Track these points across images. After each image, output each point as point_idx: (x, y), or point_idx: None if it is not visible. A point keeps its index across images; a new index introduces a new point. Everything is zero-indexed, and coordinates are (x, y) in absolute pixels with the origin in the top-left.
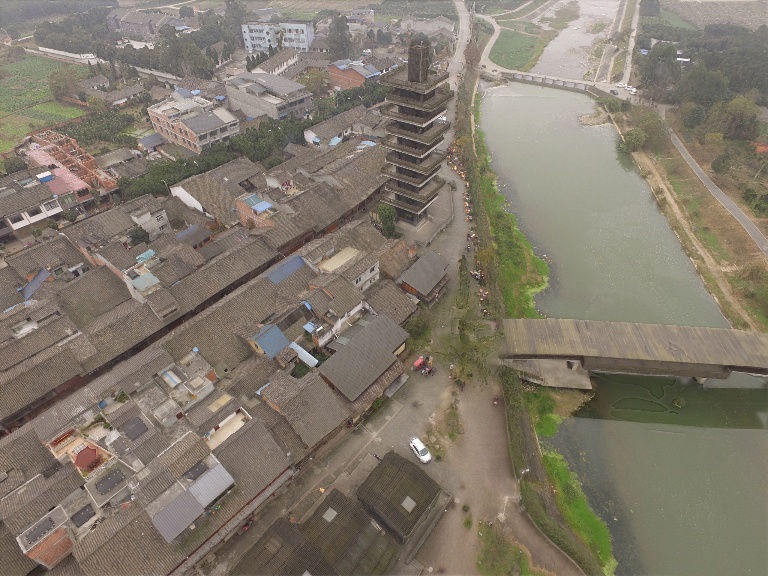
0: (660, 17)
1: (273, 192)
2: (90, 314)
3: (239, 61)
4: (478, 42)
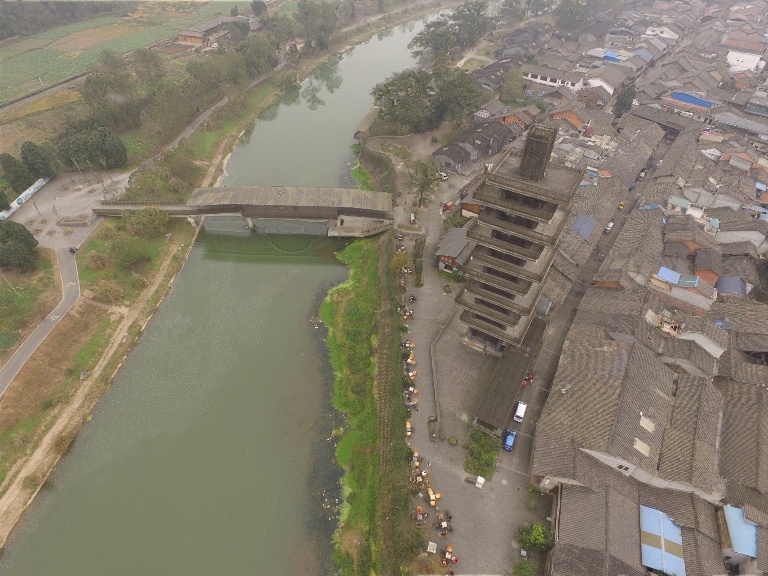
0: None
1: None
2: (708, 216)
3: None
4: None
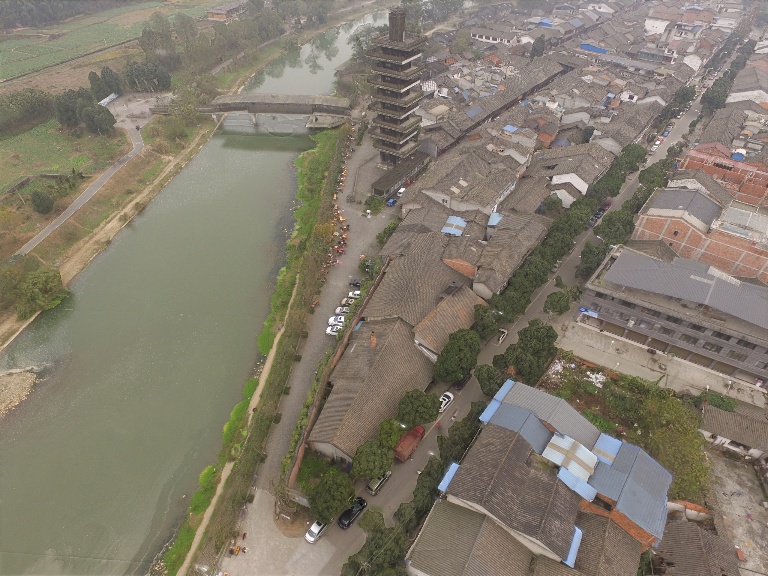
0: None
1: None
2: None
3: None
4: None
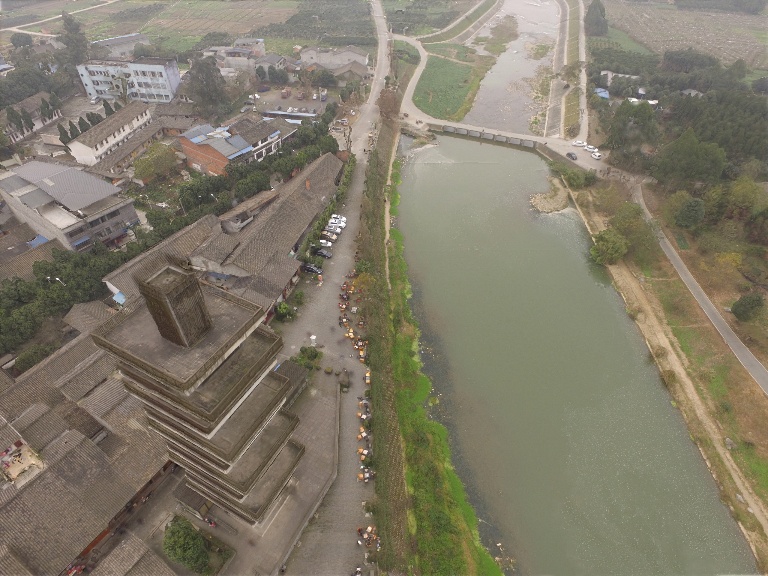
0: (608, 37)
1: None
2: None
3: (72, 118)
4: (399, 78)
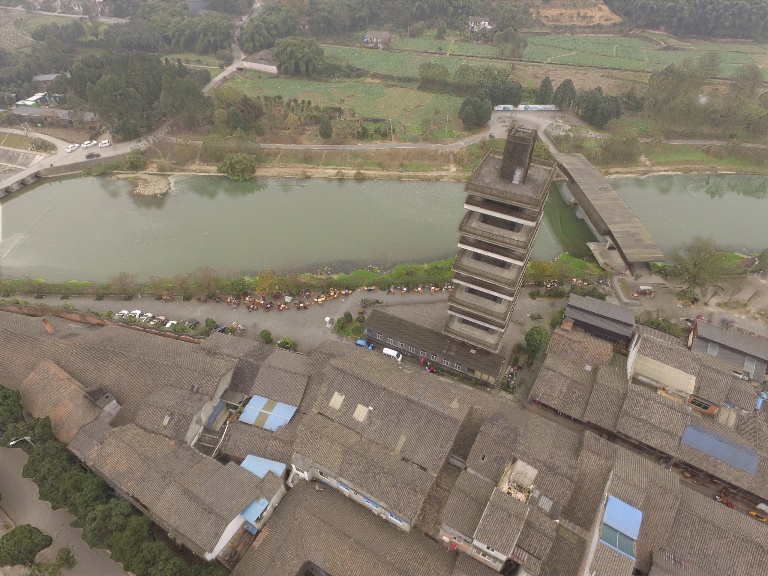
0: None
1: (541, 528)
2: None
3: None
4: None
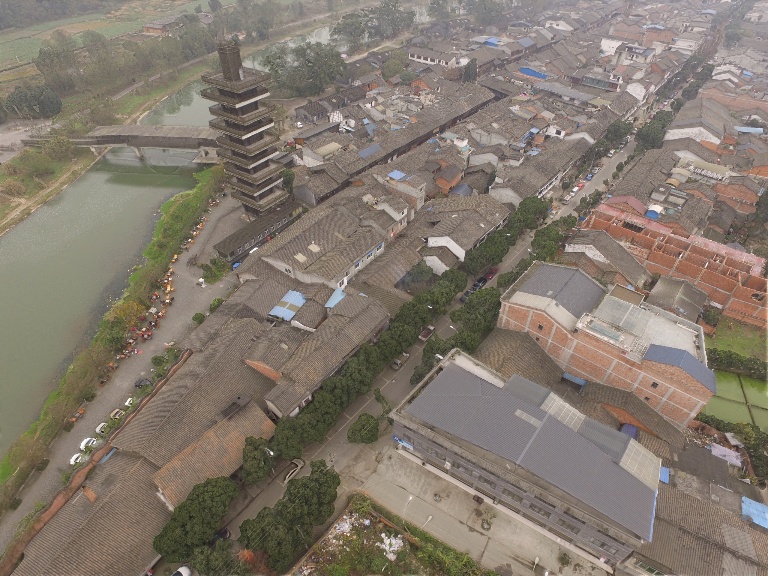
0: None
1: None
2: None
3: None
4: None
